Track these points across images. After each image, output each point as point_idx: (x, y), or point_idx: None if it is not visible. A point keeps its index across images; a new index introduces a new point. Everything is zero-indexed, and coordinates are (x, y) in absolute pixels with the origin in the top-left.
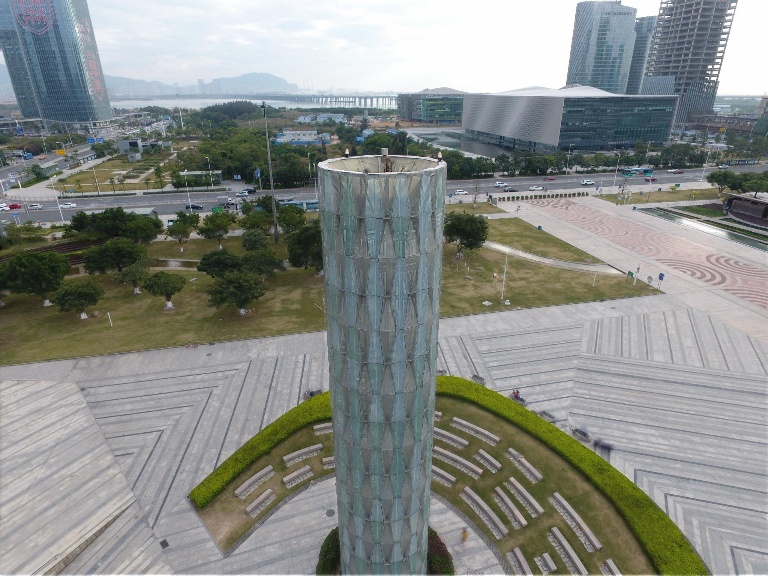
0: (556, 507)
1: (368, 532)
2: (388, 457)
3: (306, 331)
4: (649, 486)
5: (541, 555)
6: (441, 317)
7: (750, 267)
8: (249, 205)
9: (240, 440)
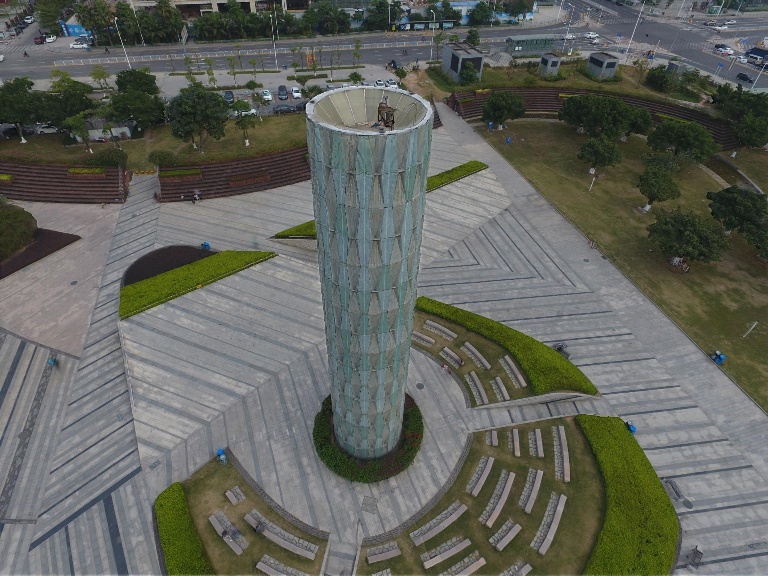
0: None
1: None
2: None
3: (680, 326)
4: None
5: None
6: None
7: None
8: None
9: (483, 311)
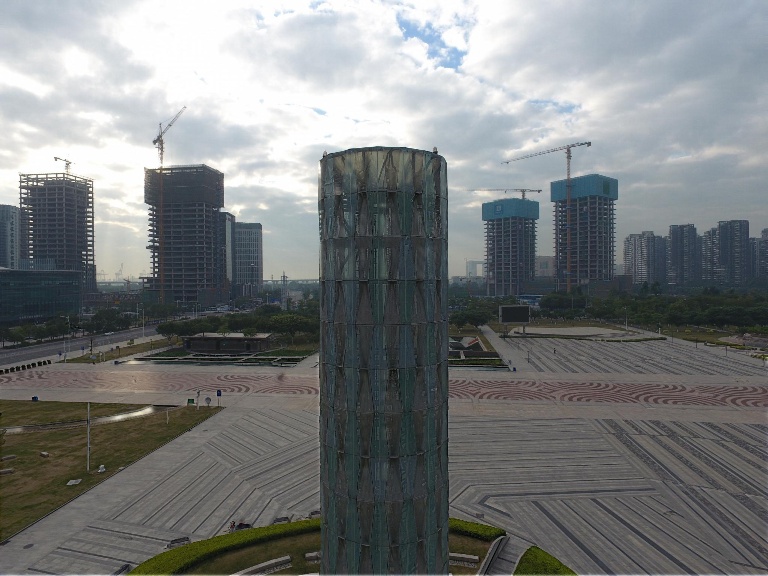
0: None
1: None
2: None
3: None
4: None
5: None
6: (27, 525)
7: (250, 376)
8: None
9: None
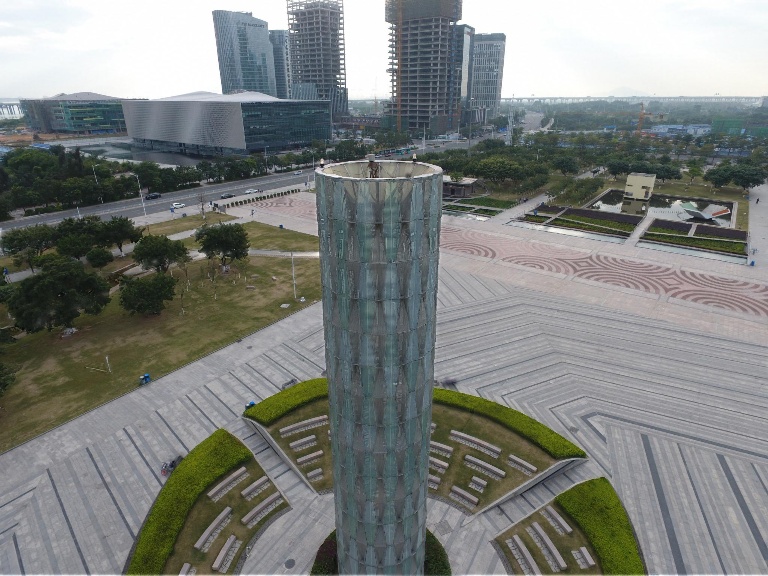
0: (458, 441)
1: (399, 534)
2: (417, 448)
3: (103, 402)
4: (490, 396)
5: (471, 480)
6: (252, 332)
7: None
8: None
9: (115, 564)
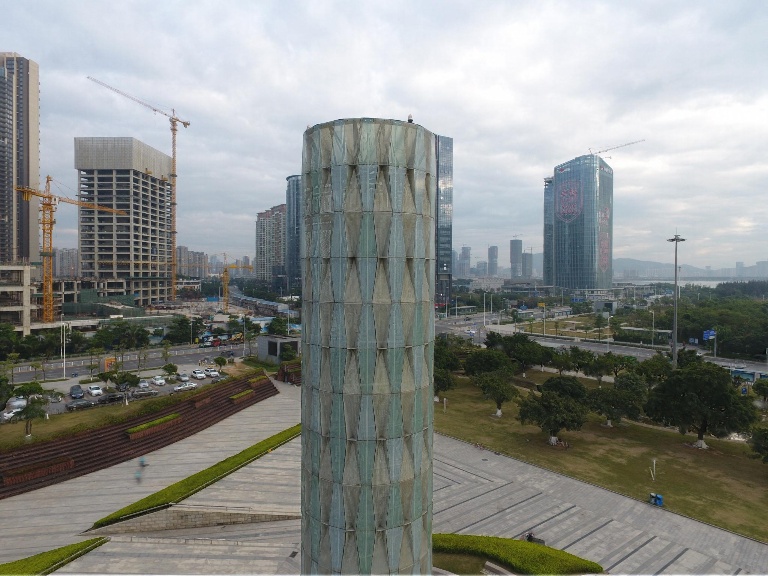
0: None
1: None
2: None
3: (604, 486)
4: None
5: None
6: None
7: None
8: (660, 356)
9: None
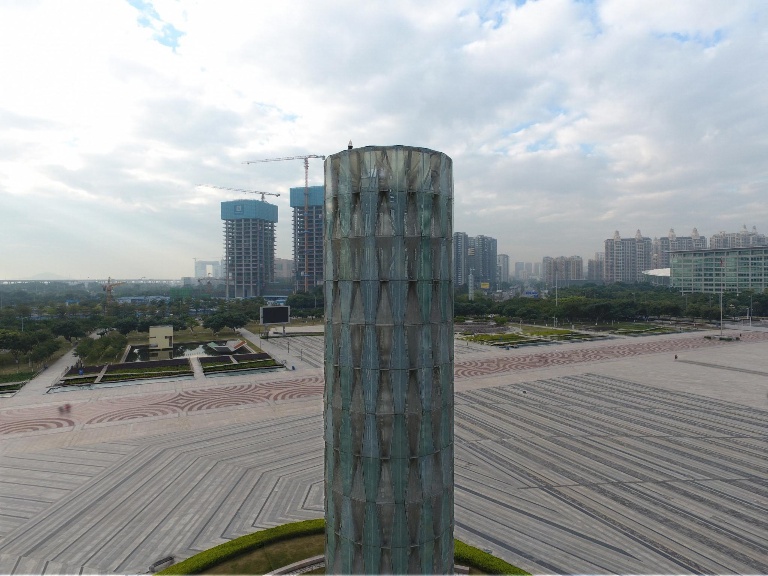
0: None
1: None
2: None
3: None
4: (242, 533)
5: None
6: None
7: None
8: None
9: None
